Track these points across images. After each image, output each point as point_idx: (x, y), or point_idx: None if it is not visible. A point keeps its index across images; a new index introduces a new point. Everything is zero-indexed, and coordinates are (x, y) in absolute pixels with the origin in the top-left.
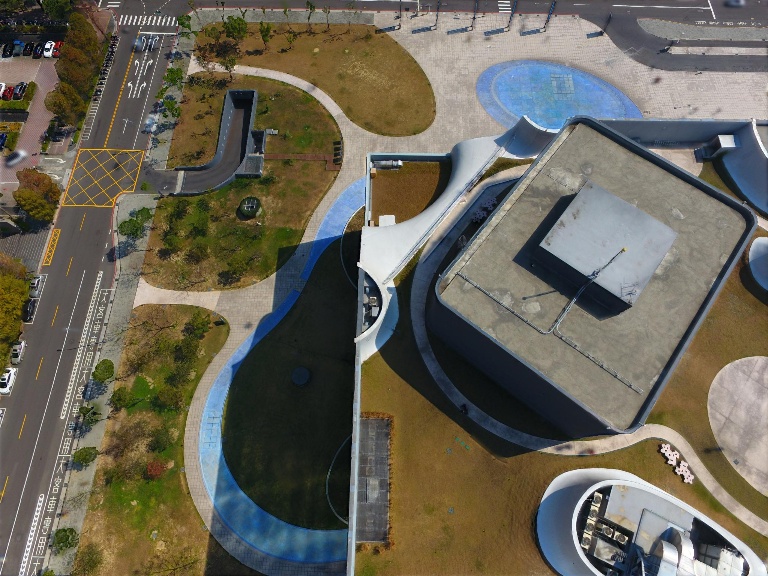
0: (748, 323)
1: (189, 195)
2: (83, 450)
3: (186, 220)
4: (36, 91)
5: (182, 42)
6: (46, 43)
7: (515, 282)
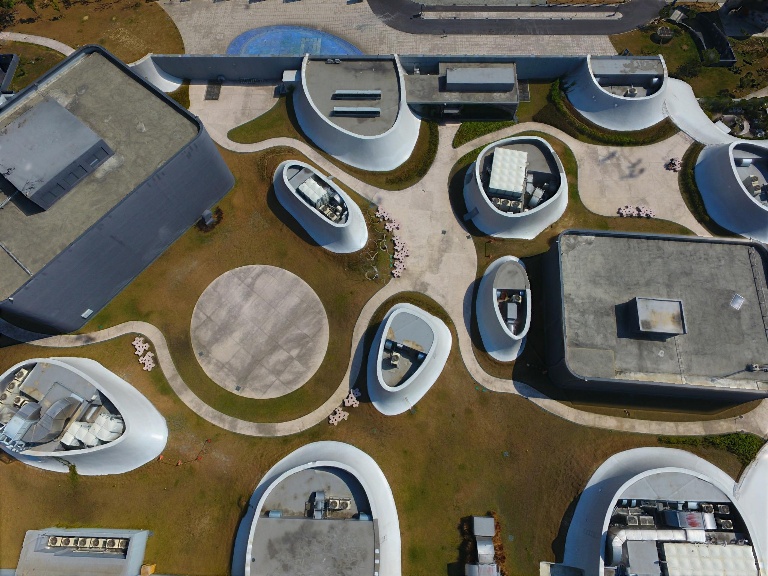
0: (260, 236)
1: None
2: None
3: None
4: None
5: None
6: None
7: None
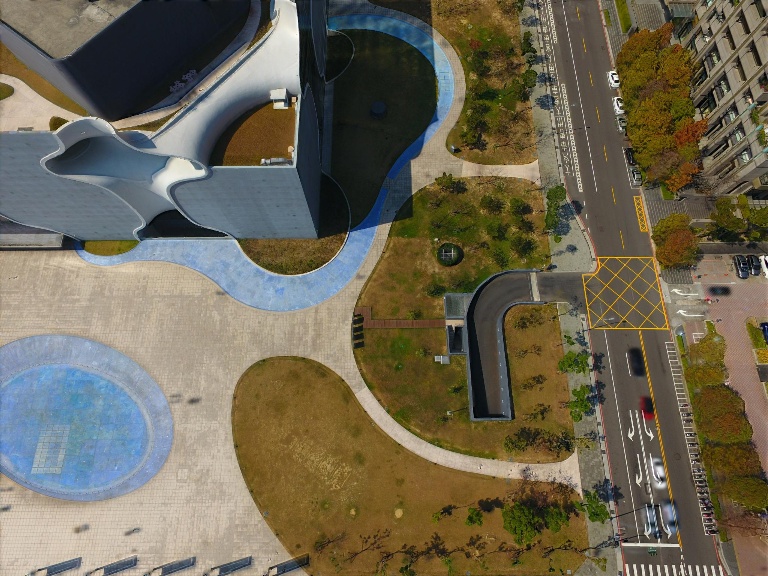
0: None
1: None
2: (526, 36)
3: None
4: None
5: (606, 524)
6: None
7: None
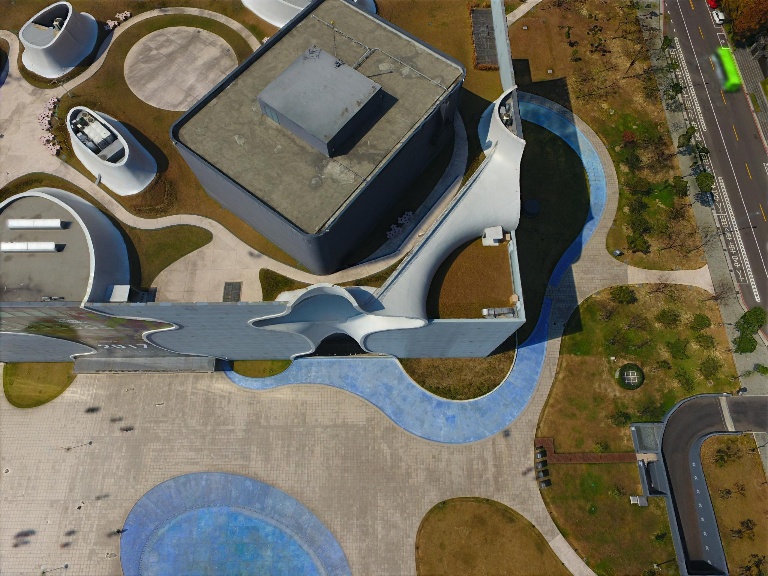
0: None
1: None
2: (691, 132)
3: (697, 362)
4: None
5: None
6: None
7: (398, 83)
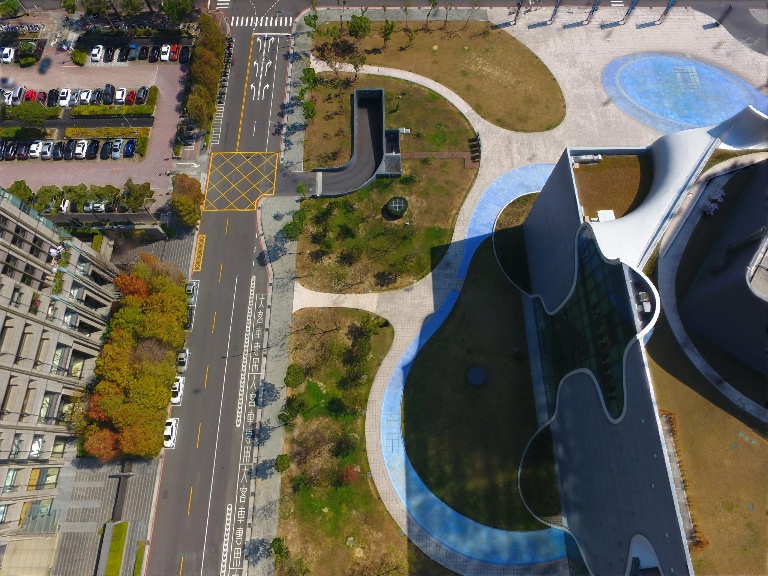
0: None
1: (332, 196)
2: (285, 458)
3: (332, 222)
4: (158, 95)
5: (299, 42)
6: (162, 46)
7: None
